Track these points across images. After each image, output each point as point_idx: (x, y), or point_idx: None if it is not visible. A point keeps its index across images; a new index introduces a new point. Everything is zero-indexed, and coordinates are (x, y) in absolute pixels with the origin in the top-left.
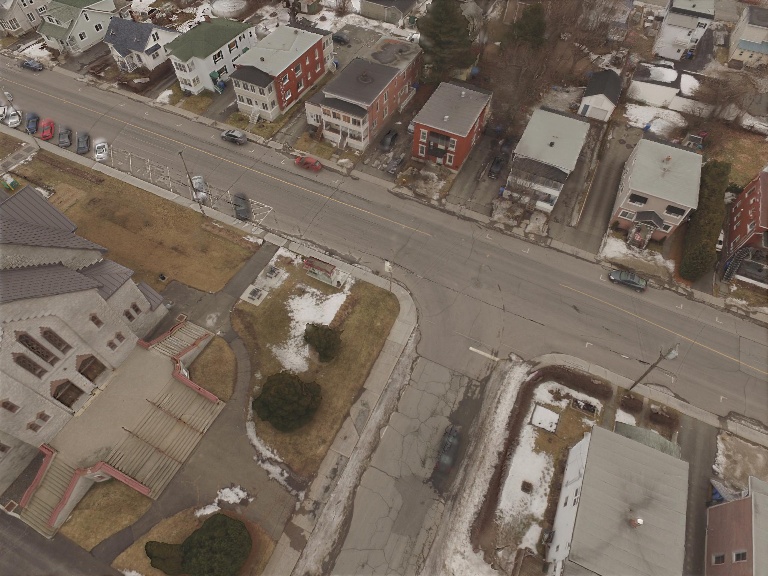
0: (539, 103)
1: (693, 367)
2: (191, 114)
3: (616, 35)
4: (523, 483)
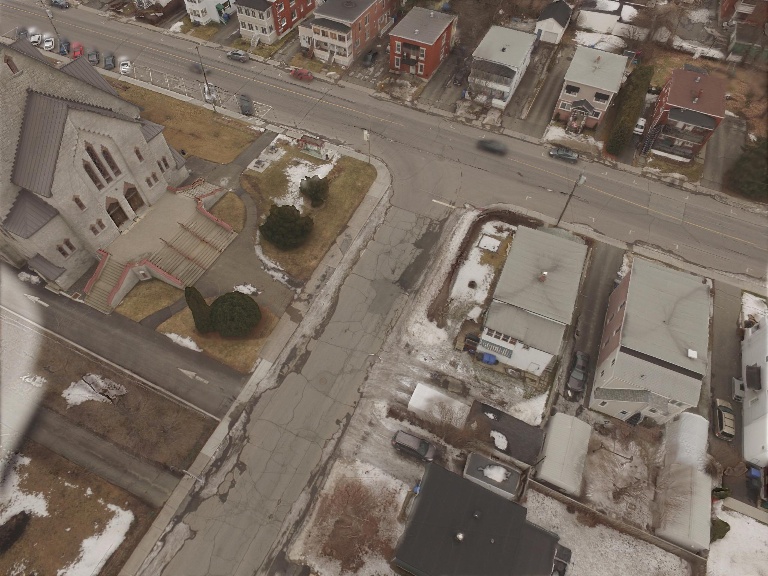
0: None
1: (610, 212)
2: (200, 40)
3: None
4: (470, 282)
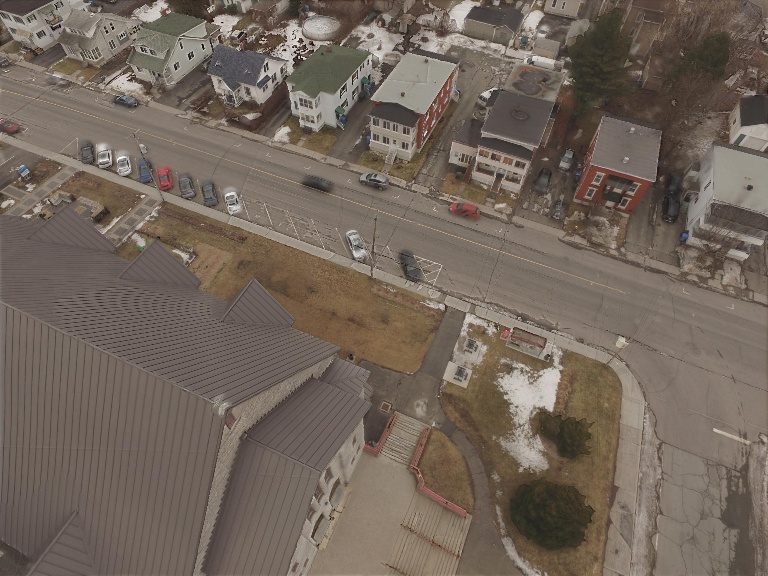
0: (685, 132)
1: None
2: (317, 154)
3: (743, 53)
4: None
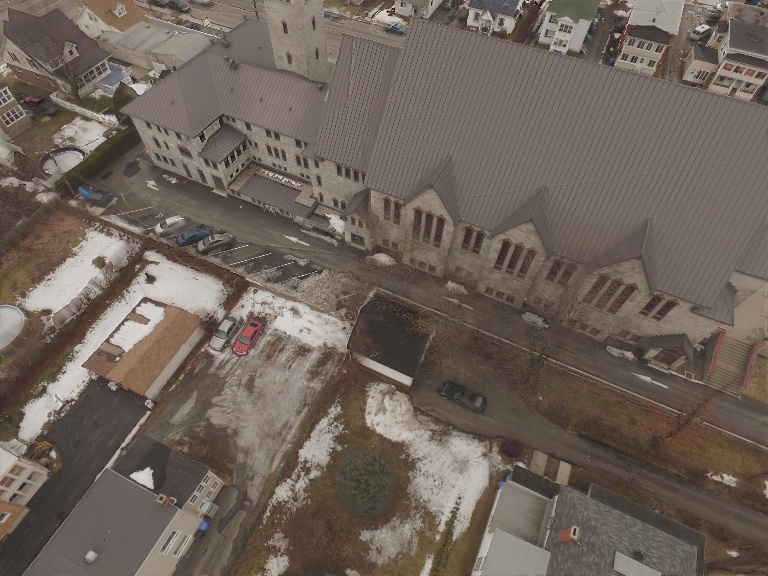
0: None
1: None
2: None
3: None
4: None
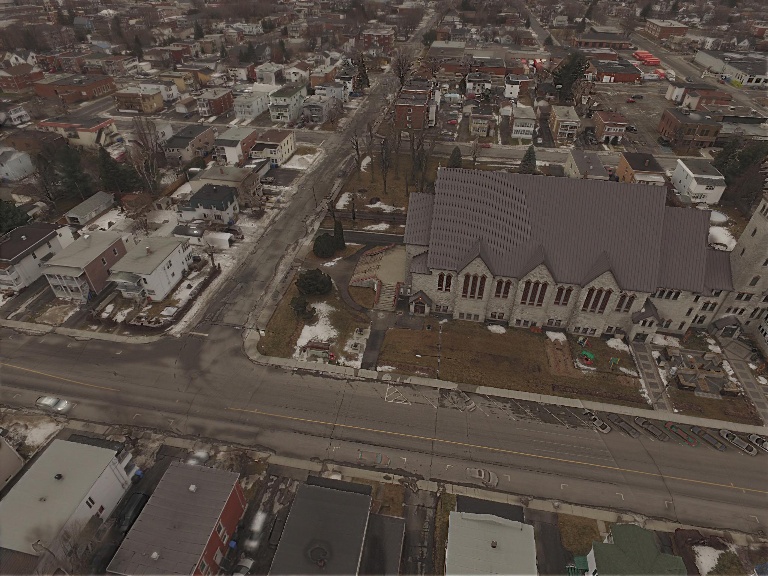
0: None
1: (47, 354)
2: (568, 510)
3: None
4: (191, 288)
